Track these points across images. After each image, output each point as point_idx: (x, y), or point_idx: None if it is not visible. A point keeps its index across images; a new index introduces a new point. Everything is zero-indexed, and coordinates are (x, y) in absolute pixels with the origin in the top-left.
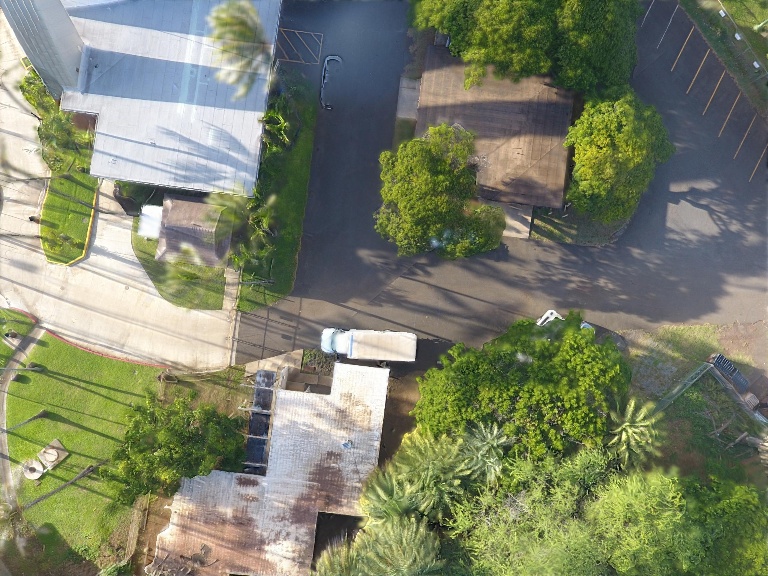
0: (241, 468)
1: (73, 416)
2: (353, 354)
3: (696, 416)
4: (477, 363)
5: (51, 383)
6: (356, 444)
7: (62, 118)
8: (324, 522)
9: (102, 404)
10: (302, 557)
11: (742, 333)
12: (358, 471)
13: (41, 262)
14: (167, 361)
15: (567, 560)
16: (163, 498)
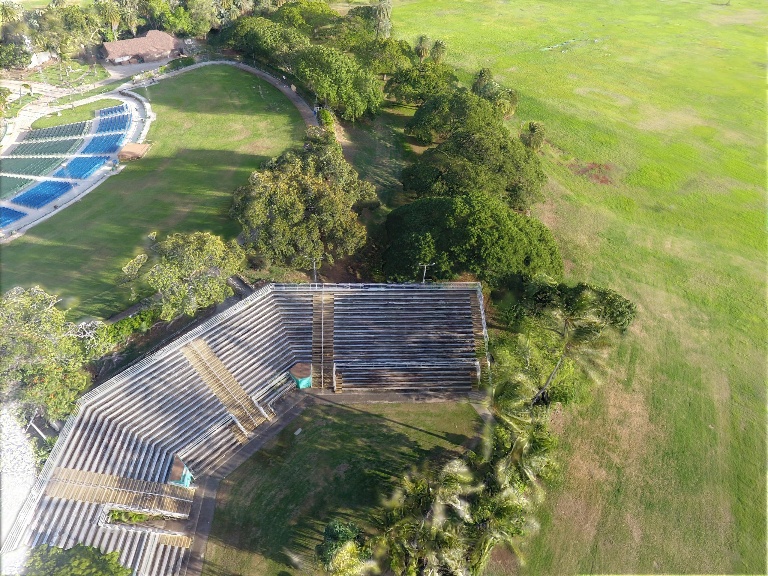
0: None
1: None
2: None
3: None
4: None
5: None
6: None
7: None
8: None
9: (47, 76)
10: None
11: None
12: None
13: None
14: None
15: None
16: None
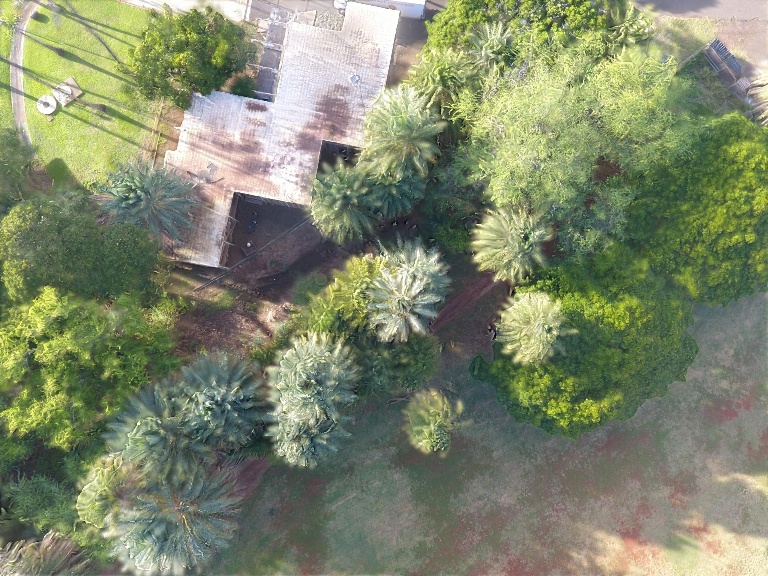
0: (251, 94)
1: (89, 57)
2: None
3: (689, 101)
4: None
5: (69, 24)
6: (363, 79)
7: None
8: (328, 153)
9: (117, 47)
10: (305, 181)
11: (738, 29)
12: (363, 105)
13: None
14: (183, 12)
15: (562, 94)
16: (172, 141)
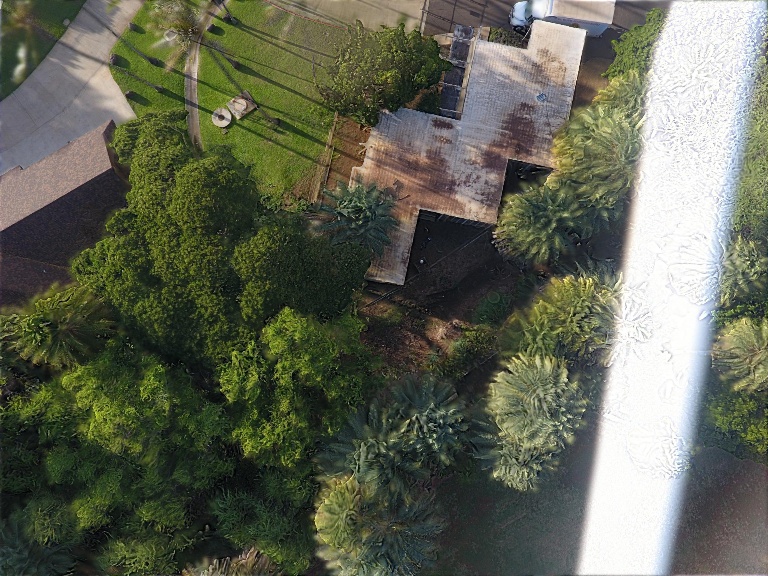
0: (437, 111)
1: (263, 70)
2: (553, 11)
3: None
4: (686, 7)
5: (244, 37)
6: (549, 98)
7: None
8: (512, 172)
9: (292, 61)
10: (490, 200)
11: None
12: (549, 124)
13: None
14: None
15: None
16: (345, 156)
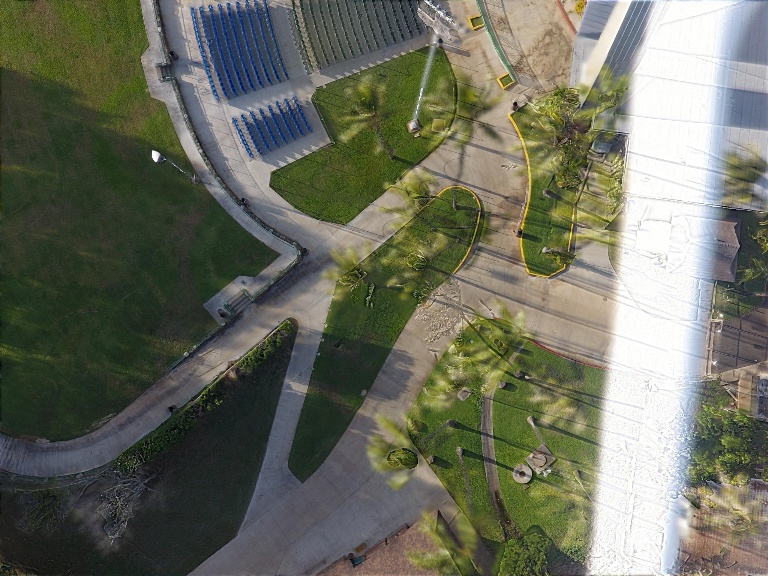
0: (754, 474)
1: (558, 423)
2: None
3: None
4: None
5: (536, 391)
6: None
7: (589, 138)
8: None
9: (586, 411)
10: None
11: None
12: None
13: (522, 274)
14: (645, 370)
15: None
16: (646, 502)
